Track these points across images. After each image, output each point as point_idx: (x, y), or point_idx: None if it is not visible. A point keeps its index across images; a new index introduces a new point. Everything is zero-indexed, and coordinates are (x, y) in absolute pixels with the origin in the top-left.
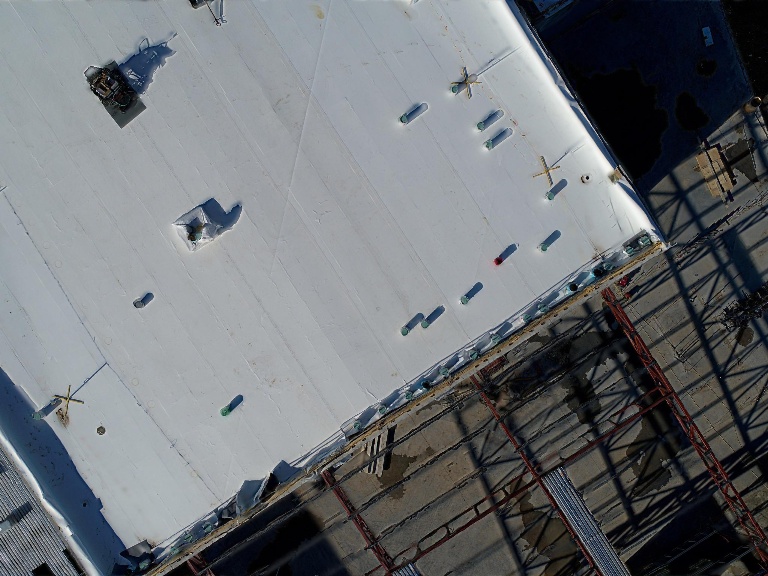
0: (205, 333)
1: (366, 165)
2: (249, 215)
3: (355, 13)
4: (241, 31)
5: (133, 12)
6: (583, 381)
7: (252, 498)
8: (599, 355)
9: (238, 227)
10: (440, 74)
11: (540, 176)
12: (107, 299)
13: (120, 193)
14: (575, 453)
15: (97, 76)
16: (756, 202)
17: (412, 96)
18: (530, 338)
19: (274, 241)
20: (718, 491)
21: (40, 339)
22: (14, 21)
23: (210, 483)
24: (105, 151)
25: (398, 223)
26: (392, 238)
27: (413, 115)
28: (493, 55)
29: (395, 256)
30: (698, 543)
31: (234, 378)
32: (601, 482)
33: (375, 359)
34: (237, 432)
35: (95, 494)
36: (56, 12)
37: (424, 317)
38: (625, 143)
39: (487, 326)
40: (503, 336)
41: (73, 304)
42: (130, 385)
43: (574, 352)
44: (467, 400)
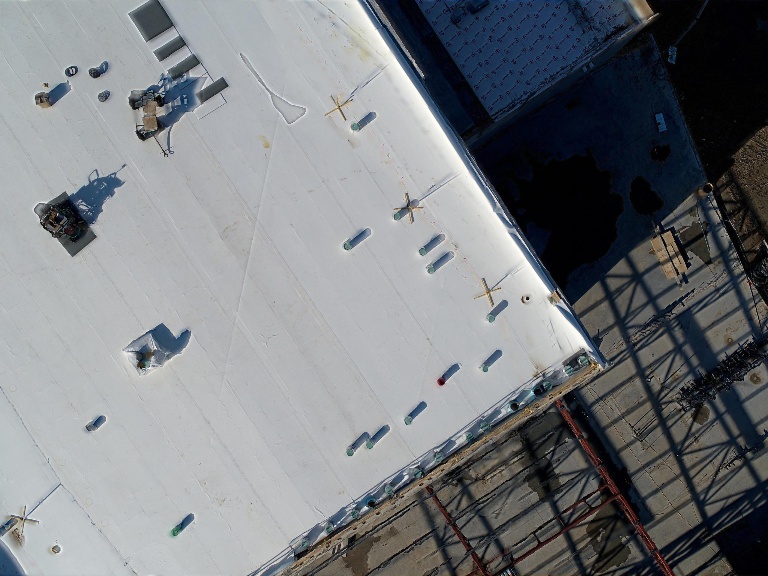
0: (157, 454)
1: (312, 289)
2: (198, 340)
3: (299, 142)
4: (188, 161)
5: (83, 144)
6: (543, 460)
7: None
8: (558, 435)
9: (187, 351)
10: (383, 200)
11: (481, 297)
12: (61, 422)
13: (72, 319)
14: (525, 554)
15: (46, 213)
16: (710, 284)
17: (356, 222)
18: None
19: (223, 364)
20: (677, 567)
21: None
22: None
23: None
24: (57, 279)
25: (343, 345)
26: (338, 360)
27: (357, 240)
28: (434, 181)
29: (341, 377)
30: None
31: (185, 497)
32: (562, 559)
33: (322, 478)
34: (189, 549)
35: None
36: (7, 145)
37: (370, 436)
38: (581, 227)
39: (431, 444)
40: (447, 454)
41: (27, 427)
42: (84, 505)
43: (534, 432)
44: None
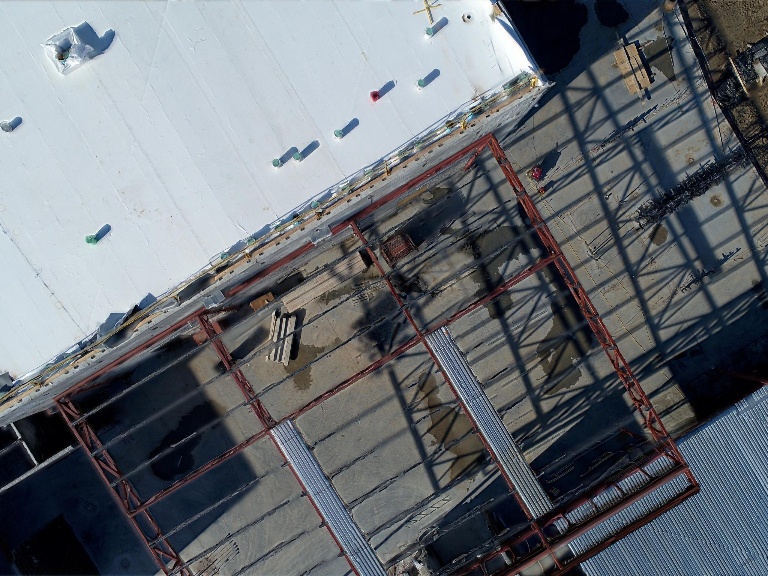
0: (74, 160)
1: None
2: (122, 40)
3: None
4: None
5: None
6: (495, 276)
7: None
8: (512, 250)
9: (110, 52)
10: None
11: (421, 13)
12: None
13: None
14: None
15: None
16: (673, 101)
17: None
18: (443, 230)
19: (147, 68)
20: None
21: None
22: None
23: (75, 315)
24: None
25: (274, 54)
26: (268, 69)
27: None
28: None
29: (270, 88)
30: (605, 441)
31: (102, 207)
32: (510, 379)
33: (247, 192)
34: (104, 263)
35: None
36: None
37: (298, 151)
38: (544, 37)
39: (362, 163)
40: (378, 173)
41: None
42: None
43: (487, 246)
44: (377, 291)
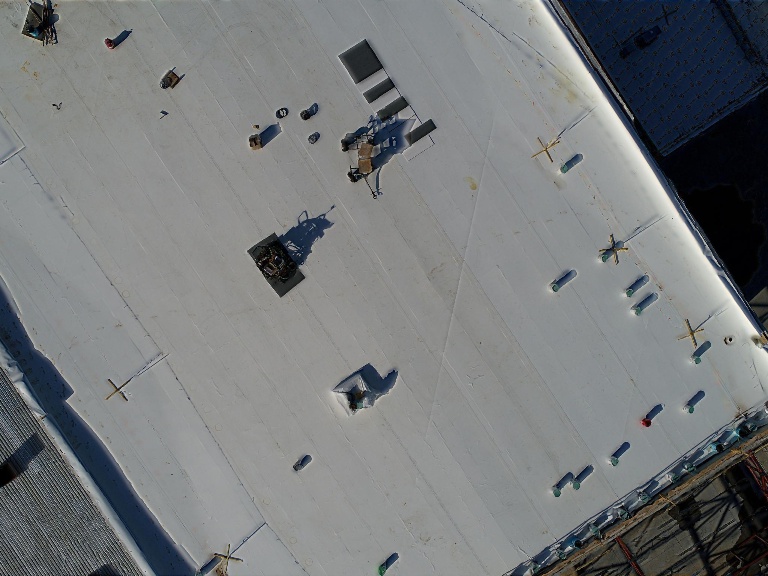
0: (361, 493)
1: (517, 330)
2: (405, 380)
3: (506, 184)
4: (396, 203)
5: (292, 186)
6: None
7: None
8: None
9: (394, 392)
10: (588, 241)
11: (685, 338)
12: (266, 461)
13: (279, 359)
14: None
15: (265, 256)
16: None
17: (561, 263)
18: None
19: (429, 405)
20: None
21: (200, 499)
22: (176, 195)
23: None
24: (265, 319)
25: (548, 386)
26: (543, 400)
27: (562, 282)
28: (639, 223)
29: (545, 418)
30: None
31: (390, 537)
32: None
33: (526, 518)
34: None
35: None
36: (217, 186)
37: (574, 476)
38: (724, 257)
39: (634, 484)
40: (650, 494)
41: (233, 466)
42: (288, 543)
43: None
44: None
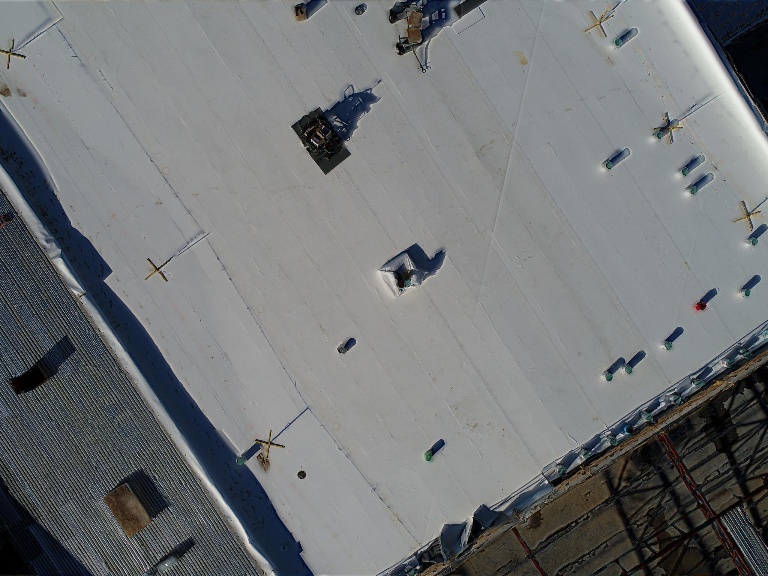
0: (407, 378)
1: (568, 210)
2: (452, 261)
3: (558, 59)
4: (445, 77)
5: (338, 59)
6: (721, 411)
7: (457, 543)
8: (737, 385)
9: (441, 273)
10: (642, 119)
11: (741, 221)
12: (309, 344)
13: (323, 239)
14: (753, 492)
15: (312, 125)
16: None
17: (614, 141)
18: None
19: (477, 287)
20: None
21: (241, 384)
22: (219, 68)
23: (410, 527)
24: (309, 197)
25: (600, 268)
26: (594, 283)
27: (615, 160)
28: (695, 100)
29: (597, 301)
30: None
31: (435, 423)
32: None
33: (576, 404)
34: (438, 476)
35: (295, 538)
36: (261, 59)
37: (625, 362)
38: None
39: (687, 370)
40: (704, 381)
41: (275, 349)
42: (331, 430)
43: None
44: None
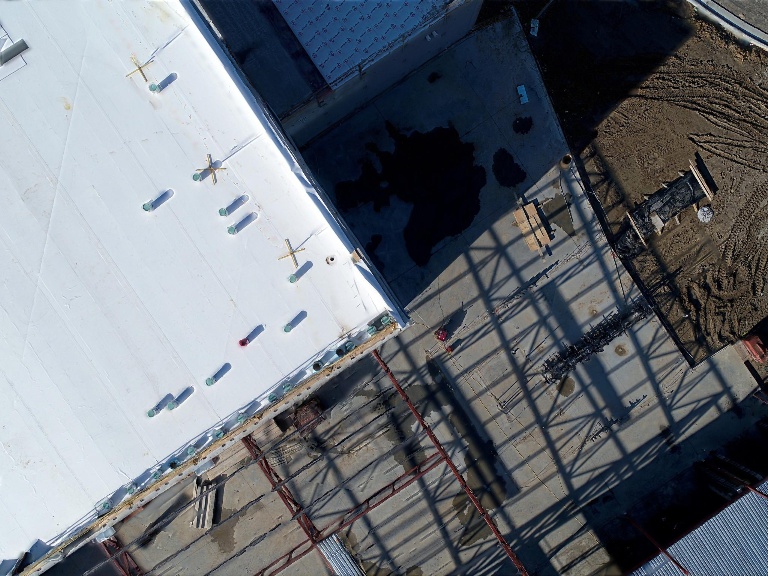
0: None
1: (114, 251)
2: None
3: (100, 103)
4: None
5: None
6: (408, 433)
7: None
8: (424, 408)
9: None
10: (185, 161)
11: (286, 258)
12: None
13: None
14: None
15: None
16: (574, 255)
17: (158, 183)
18: None
19: (25, 326)
20: (544, 539)
21: None
22: None
23: None
24: None
25: (146, 307)
26: (141, 321)
27: (159, 201)
28: (236, 142)
29: (144, 339)
30: None
31: None
32: (429, 532)
33: (127, 439)
34: None
35: None
36: None
37: (174, 397)
38: (444, 200)
39: (236, 405)
40: (251, 415)
41: None
42: None
43: (399, 405)
44: (295, 454)
